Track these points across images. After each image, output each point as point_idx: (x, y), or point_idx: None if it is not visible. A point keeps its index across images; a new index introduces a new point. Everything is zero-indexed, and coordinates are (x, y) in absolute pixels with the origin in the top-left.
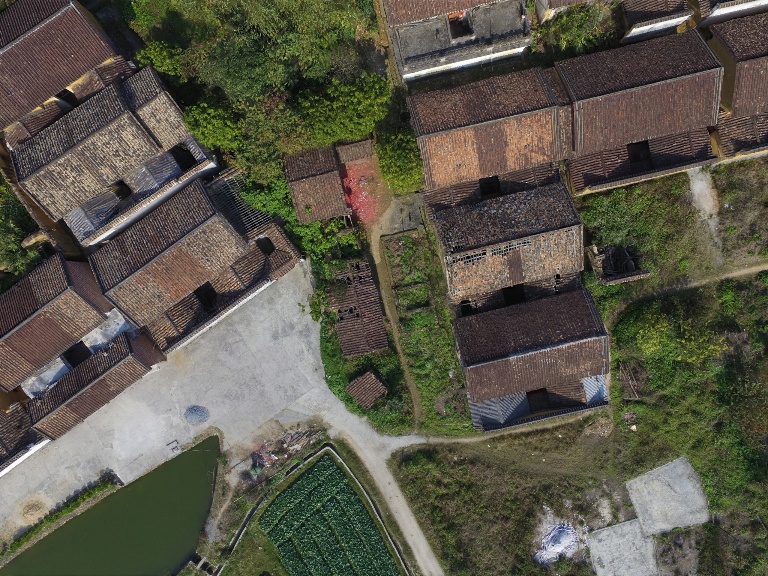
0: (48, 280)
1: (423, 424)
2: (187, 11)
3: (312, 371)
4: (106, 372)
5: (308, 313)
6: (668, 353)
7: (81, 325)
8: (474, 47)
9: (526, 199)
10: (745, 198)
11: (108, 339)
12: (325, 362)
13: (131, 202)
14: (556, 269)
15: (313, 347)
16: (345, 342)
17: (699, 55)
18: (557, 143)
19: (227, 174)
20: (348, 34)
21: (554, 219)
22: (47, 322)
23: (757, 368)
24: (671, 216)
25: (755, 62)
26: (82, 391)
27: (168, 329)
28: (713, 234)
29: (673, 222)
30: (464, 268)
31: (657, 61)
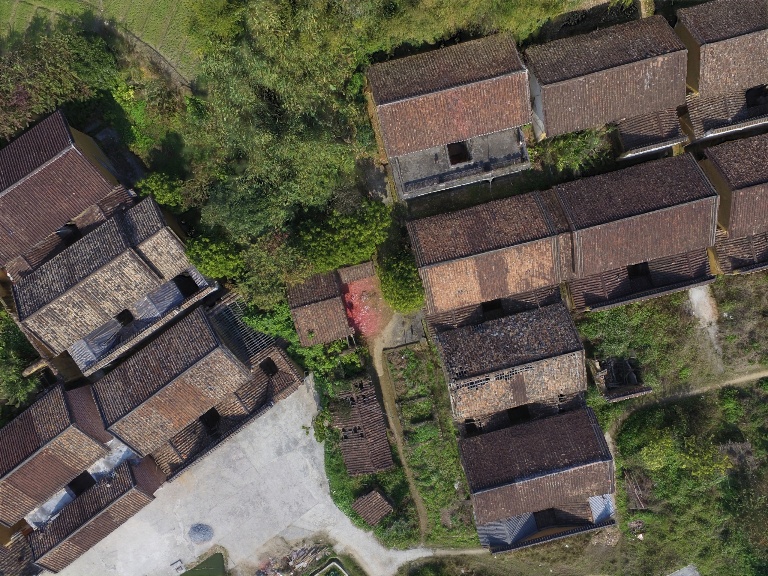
0: (50, 415)
1: (429, 537)
2: (187, 139)
3: (317, 486)
4: (109, 505)
5: (312, 428)
6: (672, 462)
7: (84, 458)
8: (473, 171)
9: (528, 321)
10: (744, 308)
11: (111, 468)
12: (330, 477)
13: (133, 329)
14: (559, 390)
15: (317, 462)
16: (350, 461)
17: (695, 181)
18: (557, 268)
19: (229, 298)
20: (348, 166)
21: (556, 343)
22: (49, 458)
23: (761, 474)
24: (671, 327)
25: (750, 189)
26: (85, 525)
27: (171, 456)
28: (713, 342)
29: (673, 333)
30: (468, 393)
31: (654, 187)
